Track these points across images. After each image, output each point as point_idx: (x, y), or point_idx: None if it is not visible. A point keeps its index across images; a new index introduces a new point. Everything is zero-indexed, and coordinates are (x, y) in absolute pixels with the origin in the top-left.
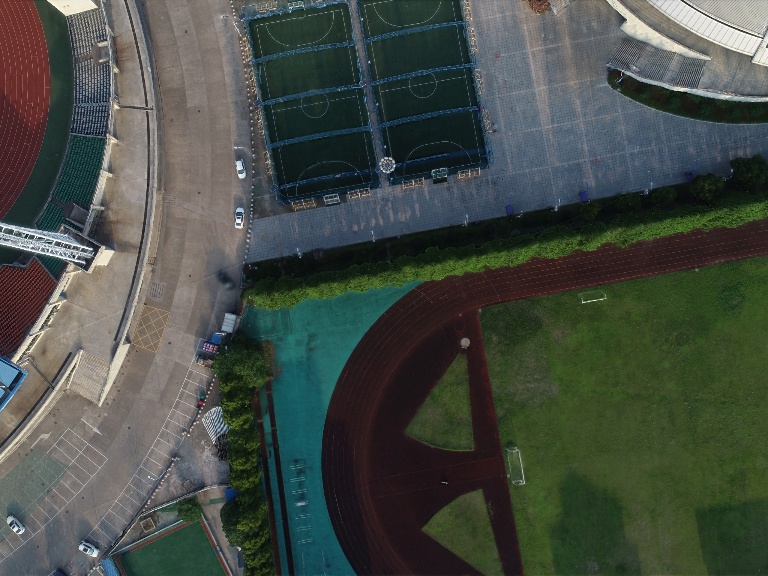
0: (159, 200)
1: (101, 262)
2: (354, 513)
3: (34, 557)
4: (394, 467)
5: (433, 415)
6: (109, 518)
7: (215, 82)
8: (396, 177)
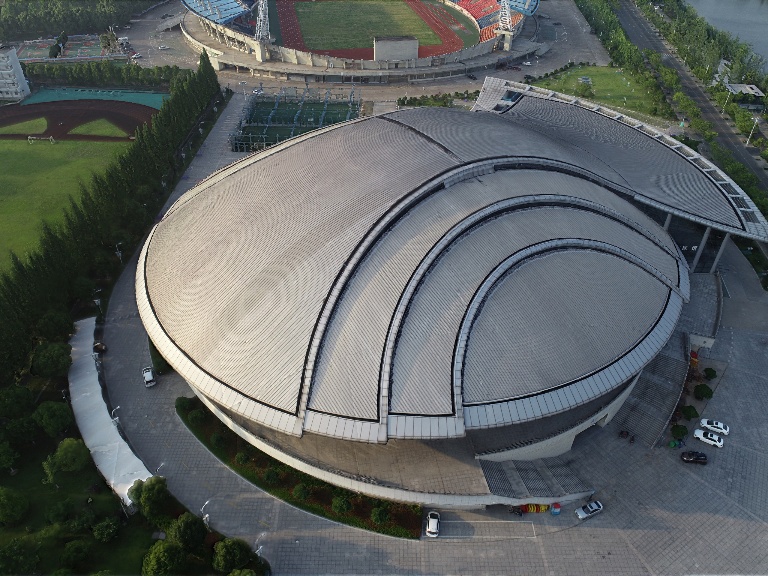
0: (282, 80)
1: (257, 54)
2: (77, 104)
3: (146, 50)
4: (87, 115)
5: (102, 126)
6: (145, 61)
7: (332, 95)
8: (248, 128)
